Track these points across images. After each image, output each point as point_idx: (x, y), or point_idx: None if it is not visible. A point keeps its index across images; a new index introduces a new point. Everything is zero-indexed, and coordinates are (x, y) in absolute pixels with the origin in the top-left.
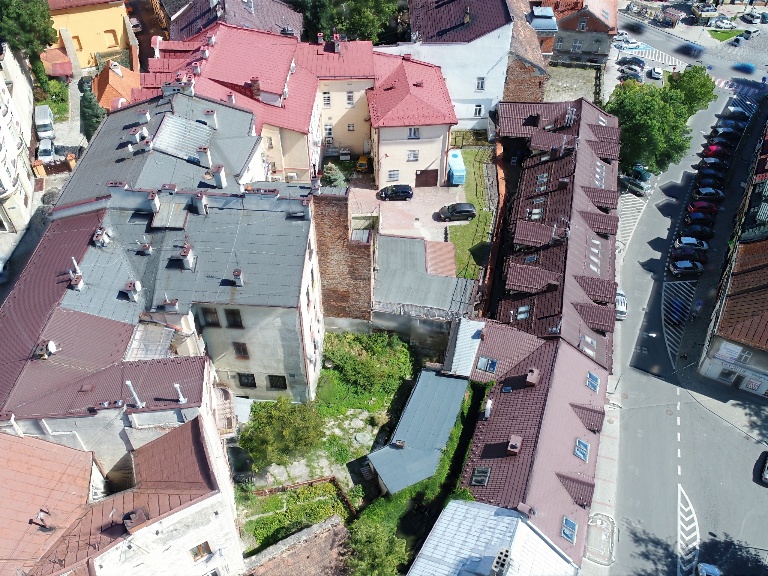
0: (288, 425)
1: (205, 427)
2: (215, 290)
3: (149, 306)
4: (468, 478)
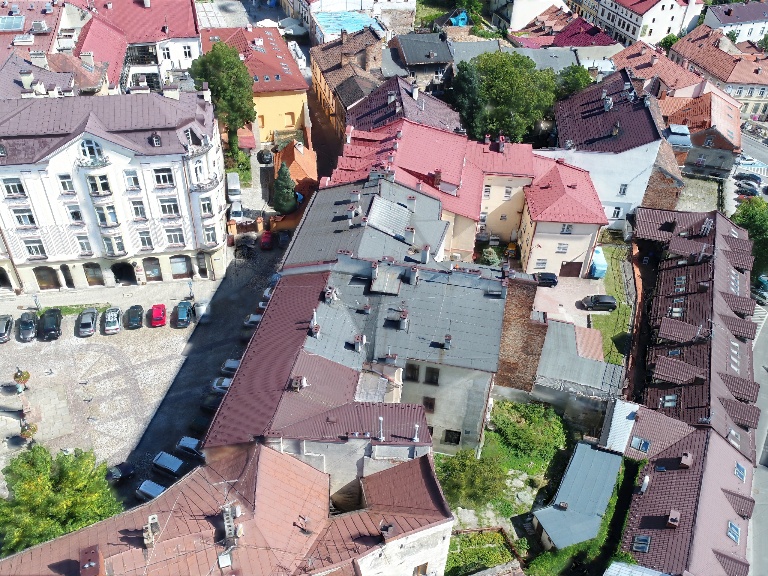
0: (478, 474)
1: None
2: (426, 350)
3: (371, 357)
4: (628, 544)
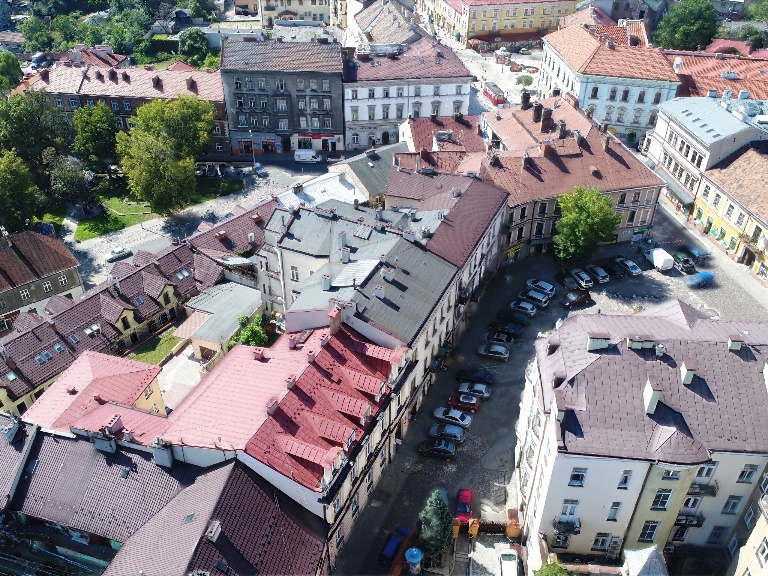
0: None
1: None
2: None
3: None
4: None
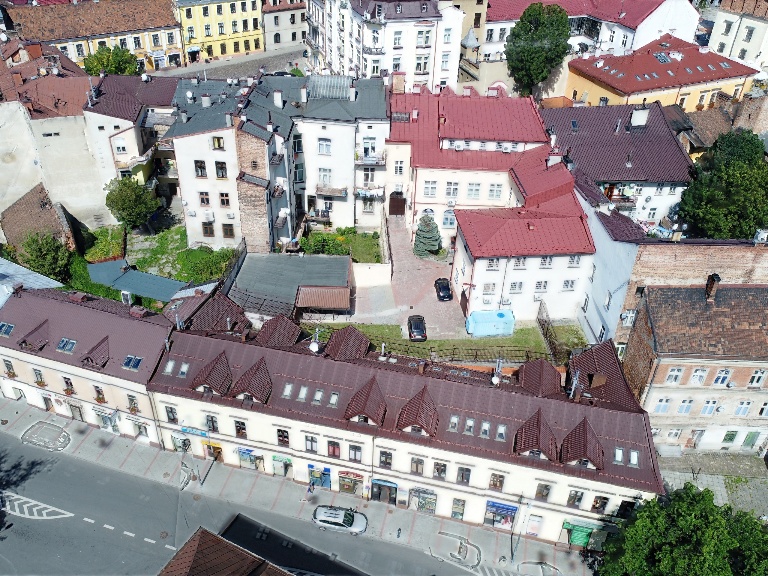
0: None
1: (85, 125)
2: None
3: None
4: None
